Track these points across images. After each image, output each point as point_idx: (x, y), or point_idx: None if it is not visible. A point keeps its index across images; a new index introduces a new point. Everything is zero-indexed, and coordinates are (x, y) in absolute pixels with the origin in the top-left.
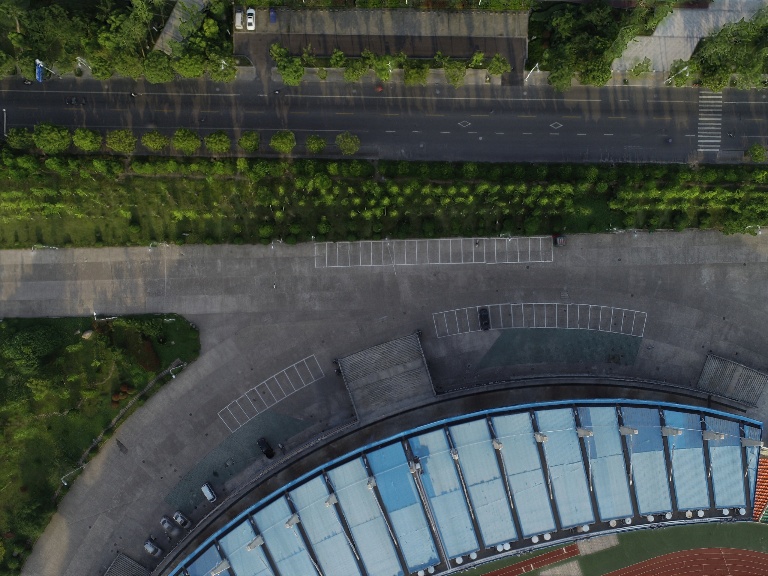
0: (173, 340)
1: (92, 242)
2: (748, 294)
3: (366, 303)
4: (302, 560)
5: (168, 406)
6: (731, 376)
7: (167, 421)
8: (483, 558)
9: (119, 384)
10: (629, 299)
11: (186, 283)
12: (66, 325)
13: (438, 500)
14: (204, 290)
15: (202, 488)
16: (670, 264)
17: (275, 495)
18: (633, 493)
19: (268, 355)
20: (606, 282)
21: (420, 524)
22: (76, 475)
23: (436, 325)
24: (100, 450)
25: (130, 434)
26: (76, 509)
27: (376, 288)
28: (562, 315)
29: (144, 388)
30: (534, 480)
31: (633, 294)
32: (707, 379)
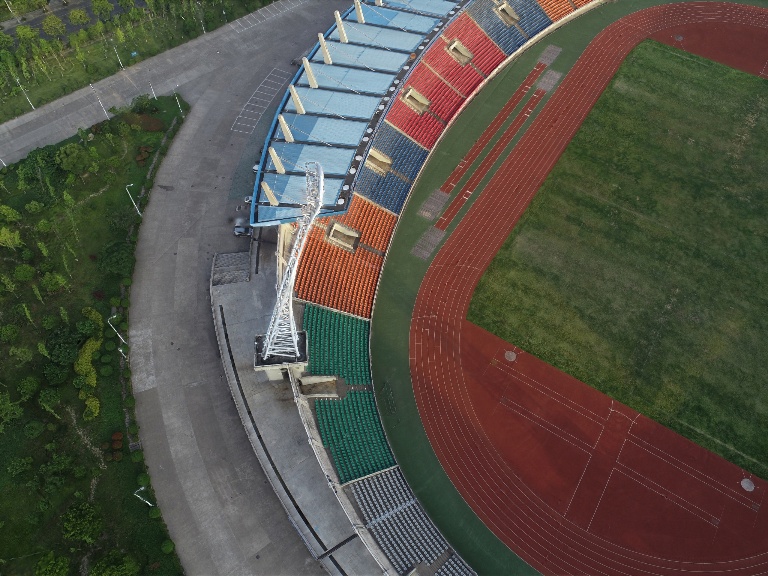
0: (164, 110)
1: (62, 93)
2: None
3: (287, 31)
4: (353, 74)
5: (188, 146)
6: None
7: (193, 154)
8: None
9: (137, 151)
10: None
11: (152, 80)
12: (68, 142)
13: None
14: (168, 77)
15: (253, 168)
16: None
17: (303, 67)
18: None
19: (242, 83)
20: None
21: (411, 17)
22: (138, 222)
23: None
24: (149, 200)
25: (168, 177)
26: (153, 249)
27: (287, 23)
28: None
29: (160, 145)
30: None
31: None
32: None
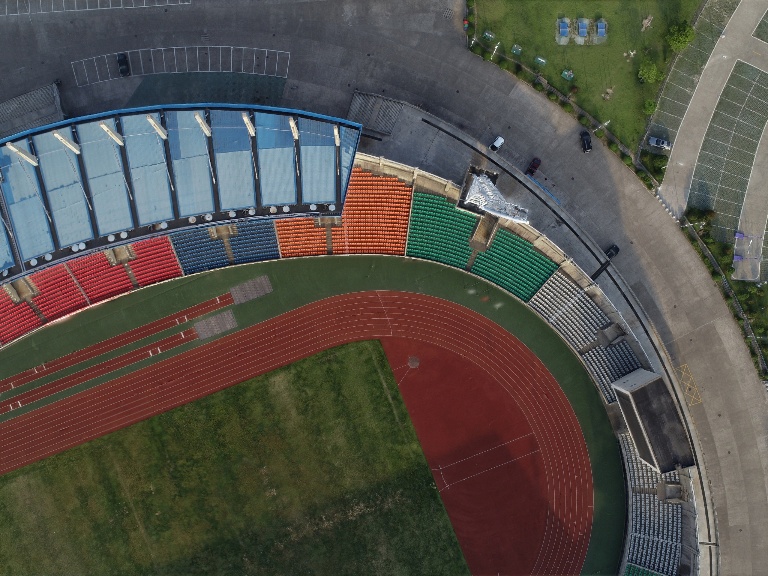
0: None
1: None
2: (392, 29)
3: (3, 54)
4: None
5: None
6: (372, 109)
7: None
8: (58, 259)
9: None
10: (271, 39)
11: None
12: None
13: (17, 206)
14: None
15: None
16: (311, 1)
17: None
18: (216, 191)
19: None
20: (246, 22)
21: None
22: None
23: (75, 74)
24: None
25: None
26: None
27: (12, 38)
28: (204, 58)
29: None
30: (114, 182)
31: (275, 34)
32: (352, 116)
